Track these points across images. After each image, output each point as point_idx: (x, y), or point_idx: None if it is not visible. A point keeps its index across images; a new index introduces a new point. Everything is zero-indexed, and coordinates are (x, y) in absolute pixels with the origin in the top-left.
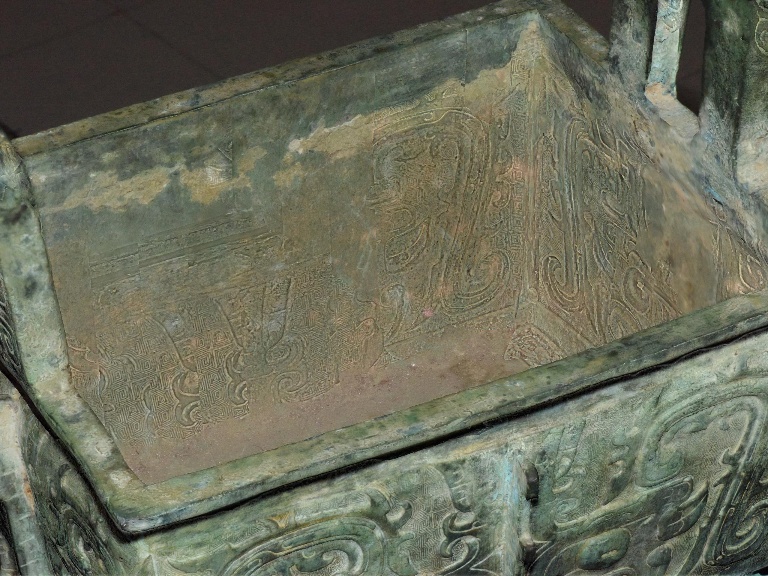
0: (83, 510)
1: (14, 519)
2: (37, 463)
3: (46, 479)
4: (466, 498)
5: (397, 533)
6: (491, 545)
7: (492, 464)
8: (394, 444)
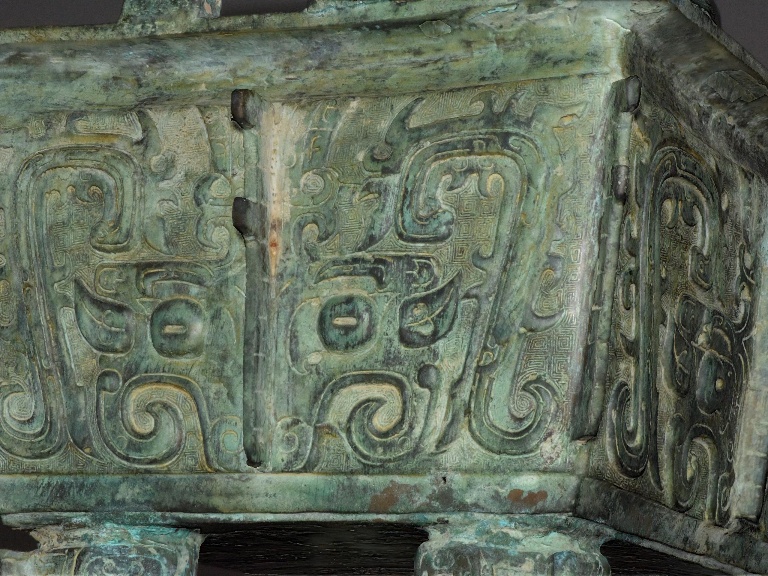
0: (469, 117)
1: (260, 275)
2: (328, 157)
3: (355, 159)
4: (749, 232)
5: (723, 229)
6: (753, 319)
7: (766, 196)
8: (760, 66)
